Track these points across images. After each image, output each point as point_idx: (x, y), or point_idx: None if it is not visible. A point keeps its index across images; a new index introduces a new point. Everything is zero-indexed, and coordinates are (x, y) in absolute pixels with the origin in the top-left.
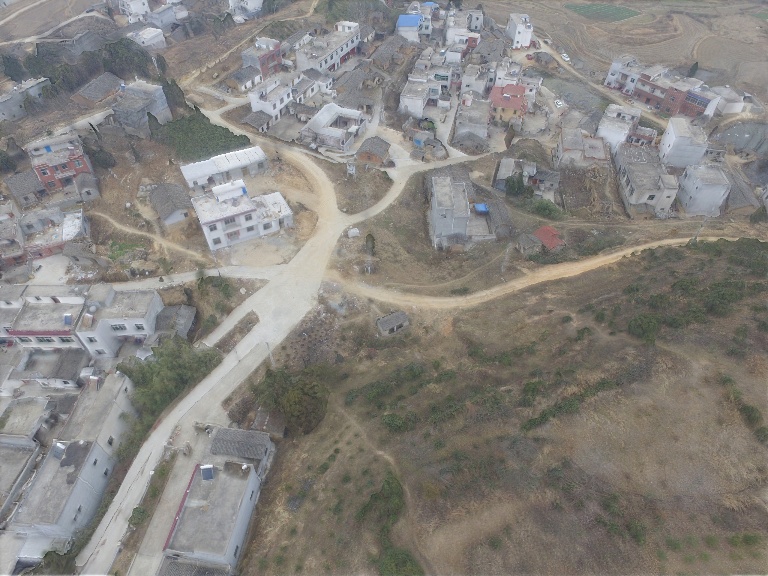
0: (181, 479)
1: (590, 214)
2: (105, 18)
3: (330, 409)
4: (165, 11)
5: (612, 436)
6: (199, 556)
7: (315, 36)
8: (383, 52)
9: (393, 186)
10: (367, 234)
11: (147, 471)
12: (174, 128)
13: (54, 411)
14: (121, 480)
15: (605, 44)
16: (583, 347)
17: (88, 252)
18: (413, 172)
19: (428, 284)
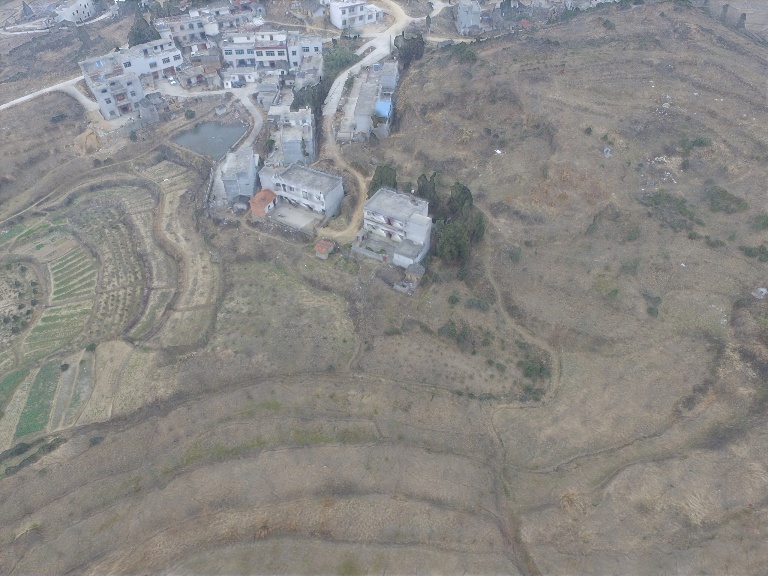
0: (359, 83)
1: None
2: None
3: (424, 56)
4: None
5: (550, 35)
6: (383, 80)
7: None
8: None
9: (434, 10)
10: (424, 23)
11: (341, 85)
12: None
13: (283, 79)
14: (329, 89)
15: None
16: None
17: None
18: (445, 6)
19: None
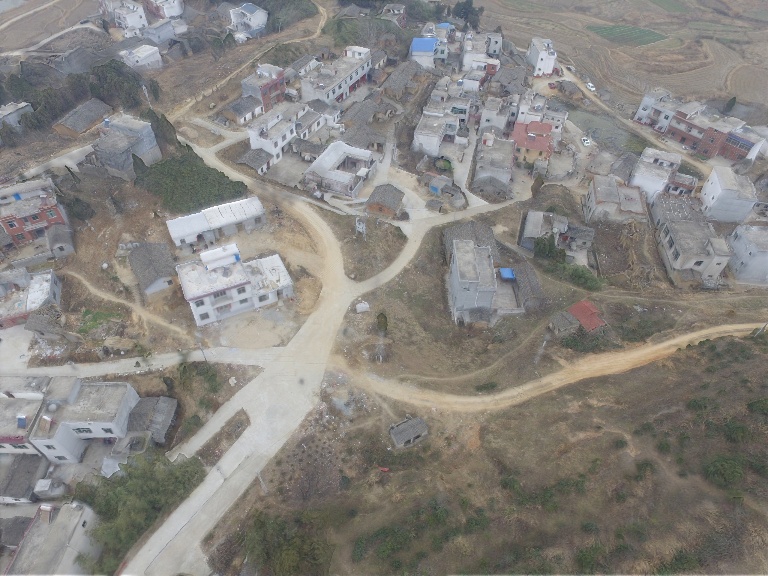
0: None
1: (629, 281)
2: (100, 30)
3: (333, 568)
4: (163, 26)
5: None
6: None
7: (322, 61)
8: (396, 81)
9: (407, 244)
10: (378, 308)
11: None
12: (162, 172)
13: None
14: None
15: (631, 71)
16: (648, 494)
17: (55, 326)
18: (430, 226)
19: (449, 376)
